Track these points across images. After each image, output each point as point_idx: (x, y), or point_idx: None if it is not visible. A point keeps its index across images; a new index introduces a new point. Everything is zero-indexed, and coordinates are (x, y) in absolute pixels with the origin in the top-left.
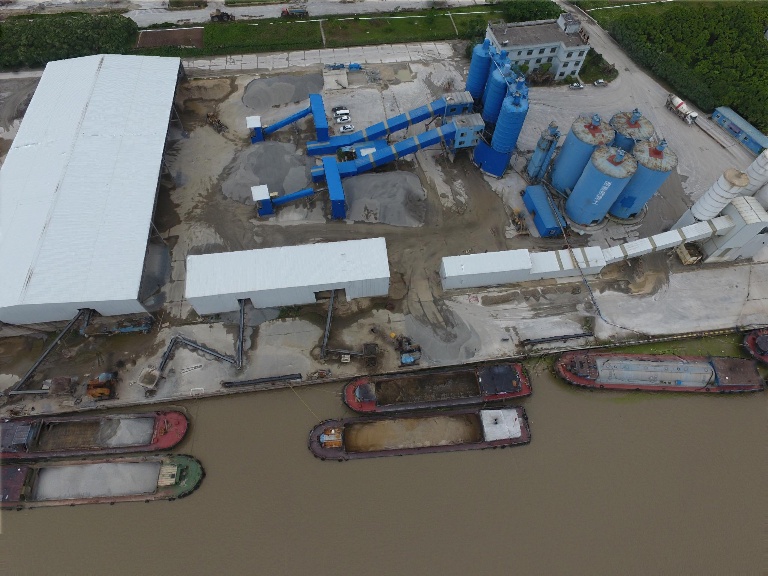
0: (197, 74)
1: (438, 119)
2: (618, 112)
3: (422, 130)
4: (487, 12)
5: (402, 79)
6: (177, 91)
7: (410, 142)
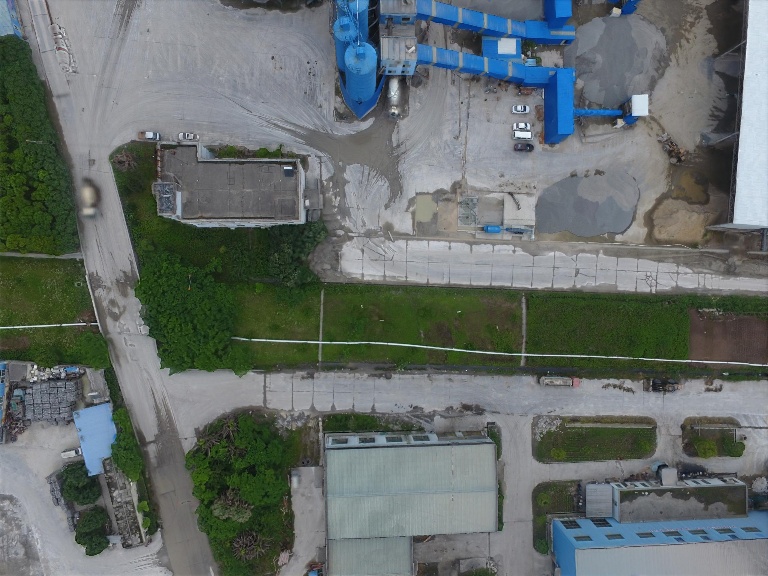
0: (694, 257)
1: (402, 109)
2: (153, 76)
3: (428, 93)
4: (258, 340)
5: (430, 201)
6: (721, 210)
7: (467, 17)
